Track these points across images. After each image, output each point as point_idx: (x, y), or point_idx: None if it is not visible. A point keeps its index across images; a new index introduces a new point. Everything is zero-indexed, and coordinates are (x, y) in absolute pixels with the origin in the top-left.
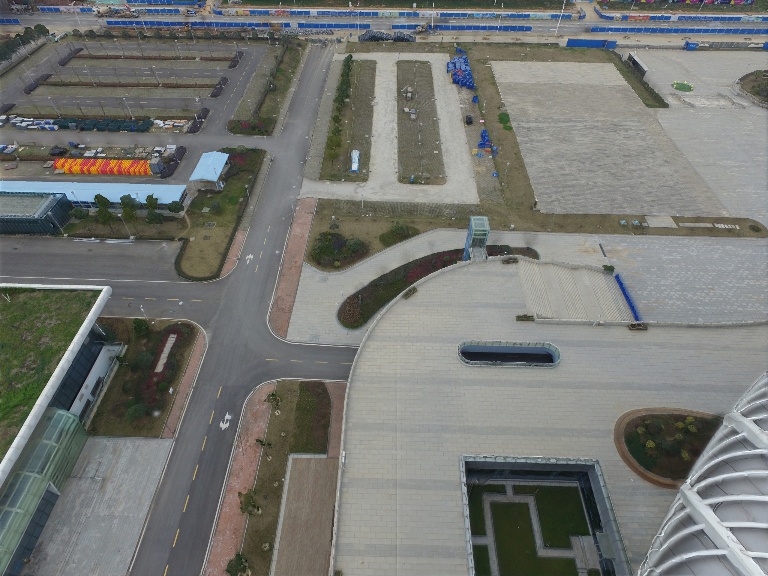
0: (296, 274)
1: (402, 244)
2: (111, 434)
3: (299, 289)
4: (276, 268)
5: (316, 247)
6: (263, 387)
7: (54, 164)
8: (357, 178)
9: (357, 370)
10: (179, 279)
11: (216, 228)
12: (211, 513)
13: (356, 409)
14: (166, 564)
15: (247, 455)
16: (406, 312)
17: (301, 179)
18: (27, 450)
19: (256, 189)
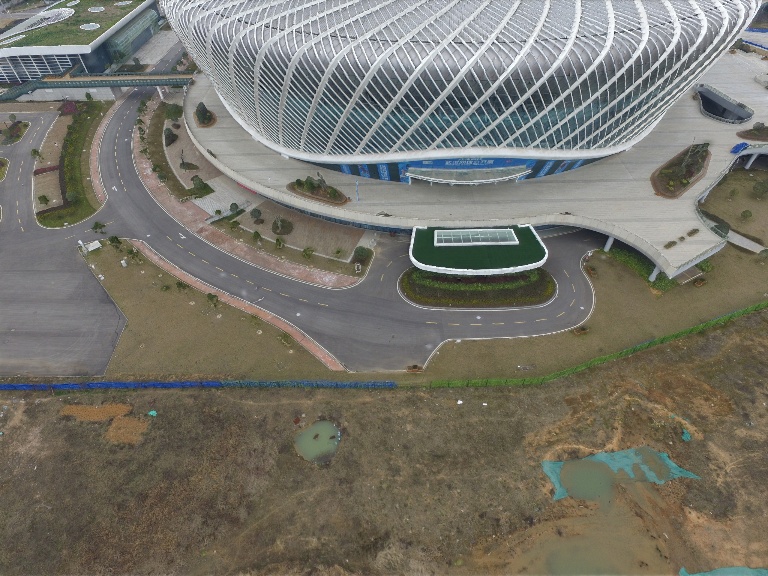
0: None
1: None
2: (167, 30)
3: None
4: None
5: None
6: None
7: None
8: None
9: None
10: None
11: None
12: None
13: None
14: None
15: None
16: None
17: None
18: (145, 13)
19: None
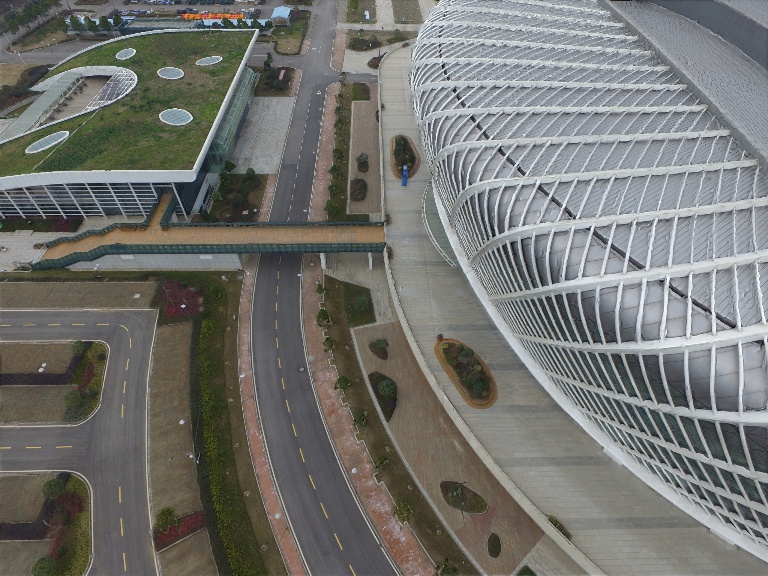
0: (342, 53)
1: (399, 43)
2: (265, 95)
3: (345, 57)
4: (330, 51)
5: (352, 40)
6: (334, 84)
7: (183, 16)
8: (369, 22)
9: (382, 65)
10: (278, 55)
11: (291, 39)
12: (321, 113)
13: (384, 74)
14: (305, 123)
15: (332, 100)
16: (404, 51)
17: (336, 22)
18: None
19: (310, 26)
